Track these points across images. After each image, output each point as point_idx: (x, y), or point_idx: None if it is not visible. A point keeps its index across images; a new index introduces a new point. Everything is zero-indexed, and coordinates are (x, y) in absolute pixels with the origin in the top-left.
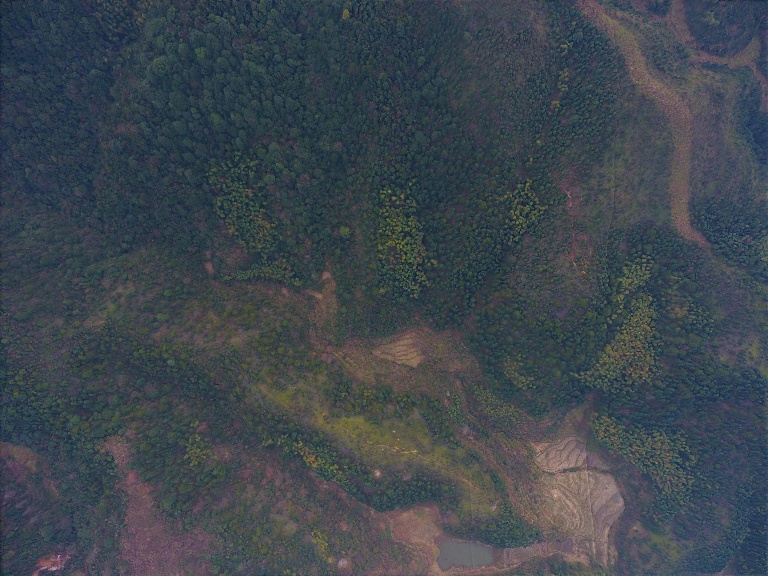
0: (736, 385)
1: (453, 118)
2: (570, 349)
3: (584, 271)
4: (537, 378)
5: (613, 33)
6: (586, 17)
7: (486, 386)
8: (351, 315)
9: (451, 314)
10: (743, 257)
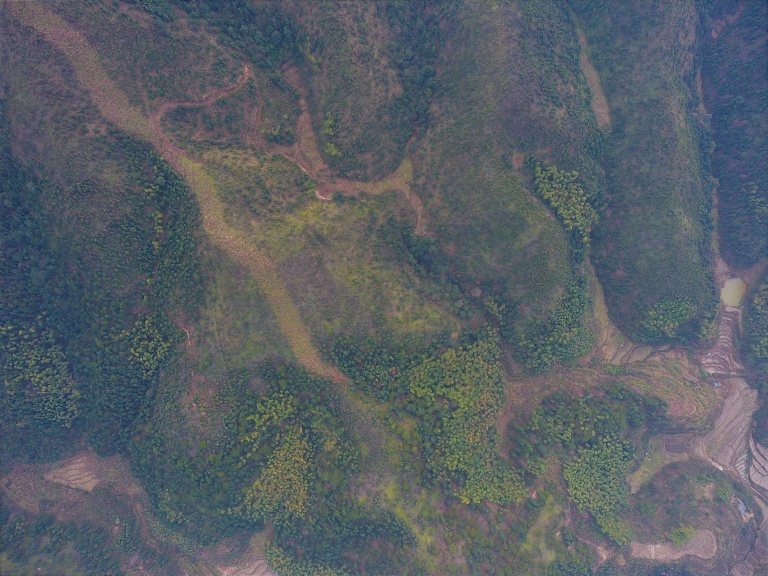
0: (378, 526)
1: (51, 259)
2: (203, 489)
3: (204, 412)
4: (189, 512)
5: (191, 179)
6: (167, 161)
7: (156, 513)
8: (2, 445)
9: (110, 442)
10: (381, 393)
